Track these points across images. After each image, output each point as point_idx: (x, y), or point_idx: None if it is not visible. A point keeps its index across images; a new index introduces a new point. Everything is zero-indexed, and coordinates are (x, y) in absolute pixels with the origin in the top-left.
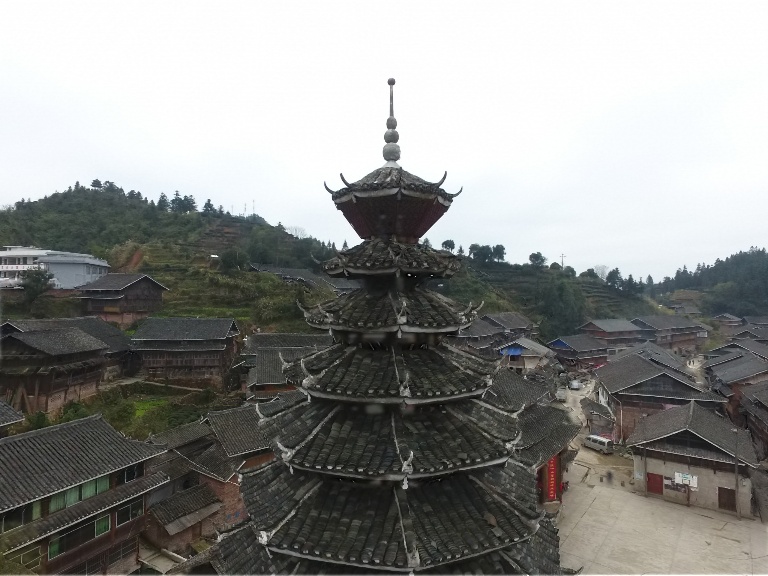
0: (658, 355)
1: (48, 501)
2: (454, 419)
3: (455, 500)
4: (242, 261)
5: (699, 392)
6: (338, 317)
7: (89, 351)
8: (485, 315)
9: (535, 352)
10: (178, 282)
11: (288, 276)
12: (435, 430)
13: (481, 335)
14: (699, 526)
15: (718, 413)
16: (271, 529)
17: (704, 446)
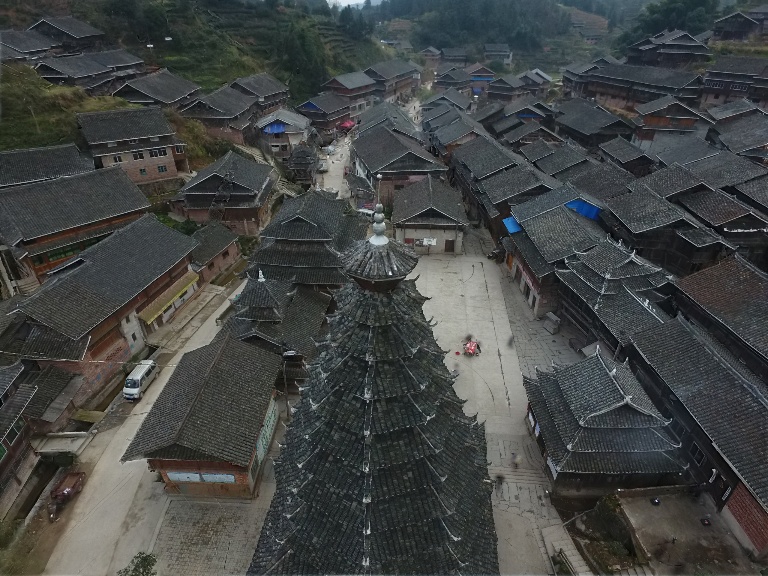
0: (396, 120)
1: None
2: None
3: None
4: None
5: (431, 163)
6: (374, 355)
7: None
8: (234, 81)
9: (298, 128)
10: None
11: None
12: None
13: (240, 112)
14: (436, 268)
15: (442, 177)
16: None
17: (440, 215)
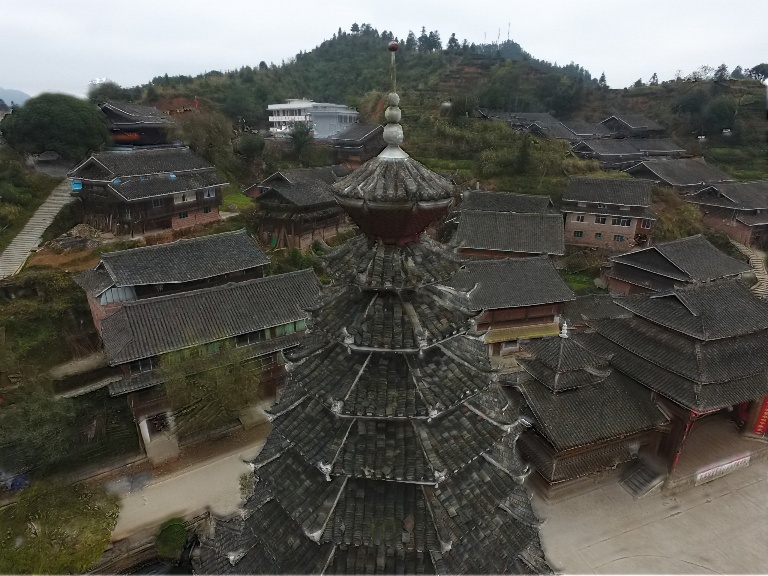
0: None
1: (273, 329)
2: (408, 428)
3: (390, 495)
4: (471, 106)
5: None
6: (317, 316)
7: (327, 202)
8: None
9: None
10: (411, 130)
11: (518, 123)
12: (385, 434)
13: (763, 207)
14: None
15: None
16: (258, 463)
17: None
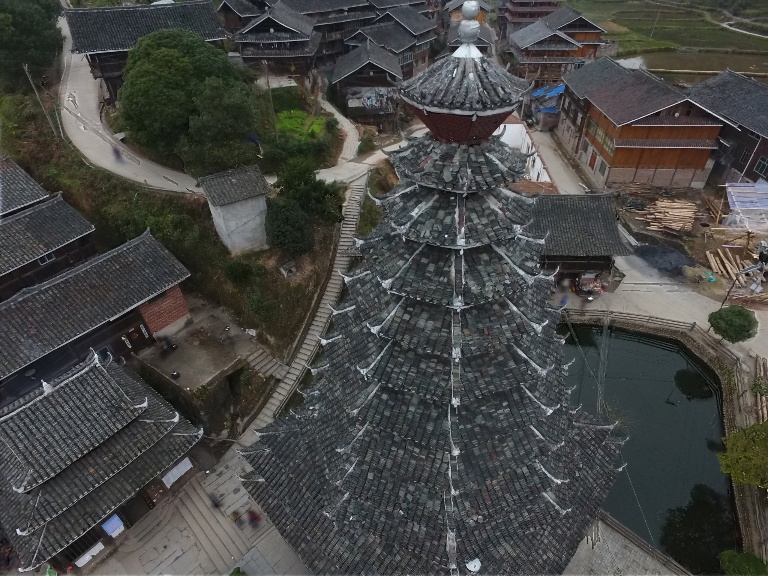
0: None
1: None
2: None
3: None
4: None
5: None
6: None
7: None
8: None
9: None
10: None
11: None
12: None
13: None
14: None
15: None
16: None
17: None
